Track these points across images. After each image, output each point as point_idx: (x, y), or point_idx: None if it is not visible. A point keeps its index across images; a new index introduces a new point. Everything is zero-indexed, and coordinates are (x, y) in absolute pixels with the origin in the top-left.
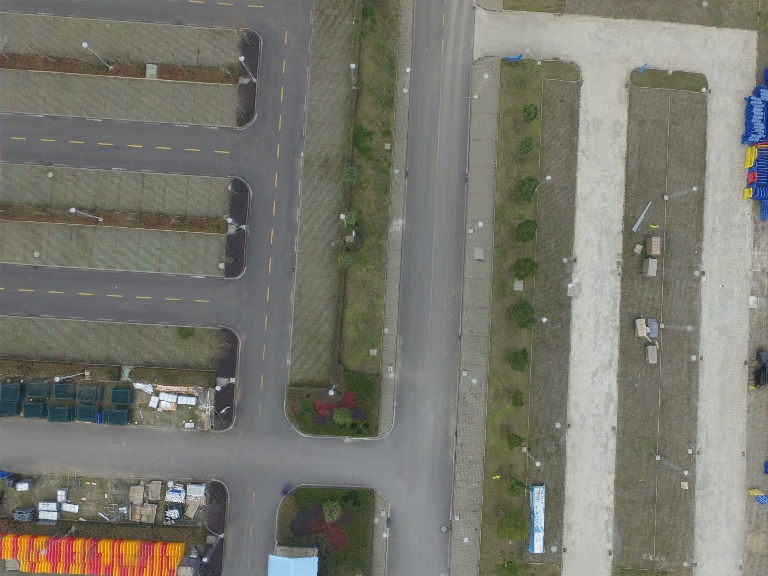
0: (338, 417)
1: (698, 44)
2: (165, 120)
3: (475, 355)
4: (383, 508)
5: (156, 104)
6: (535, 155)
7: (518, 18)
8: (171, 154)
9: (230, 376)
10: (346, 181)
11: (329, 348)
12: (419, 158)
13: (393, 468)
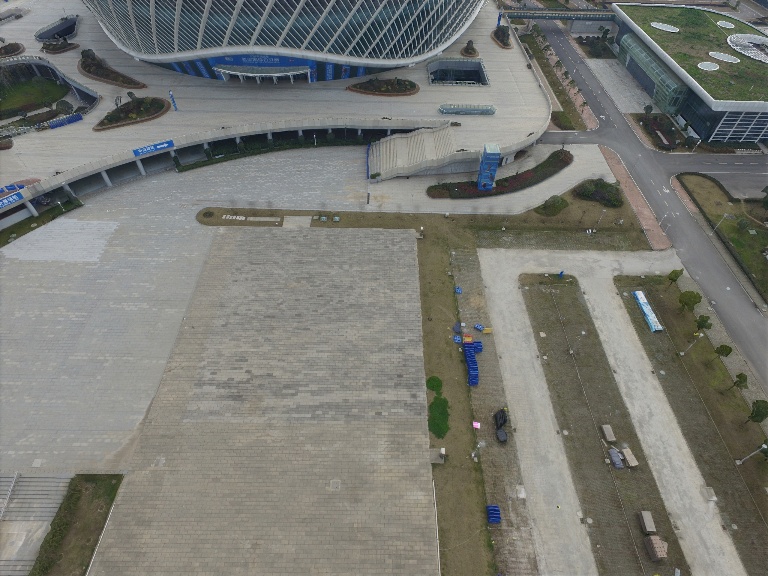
0: None
1: None
2: None
3: None
4: (766, 313)
5: None
6: None
7: None
8: None
9: None
10: None
11: None
12: None
13: None
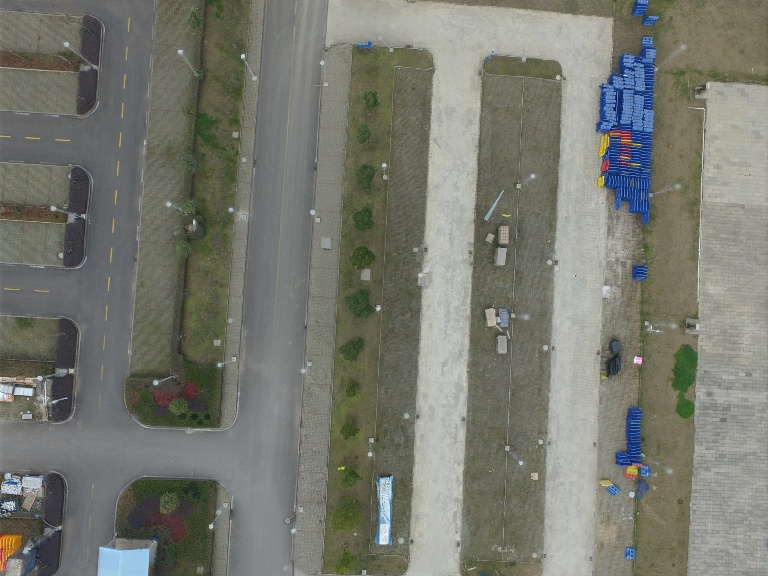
0: (172, 408)
1: (553, 31)
2: (5, 108)
3: (321, 345)
4: (225, 500)
5: None
6: (386, 143)
7: (371, 5)
8: (11, 142)
9: (68, 367)
10: (184, 169)
11: (170, 338)
12: (268, 146)
13: (236, 459)
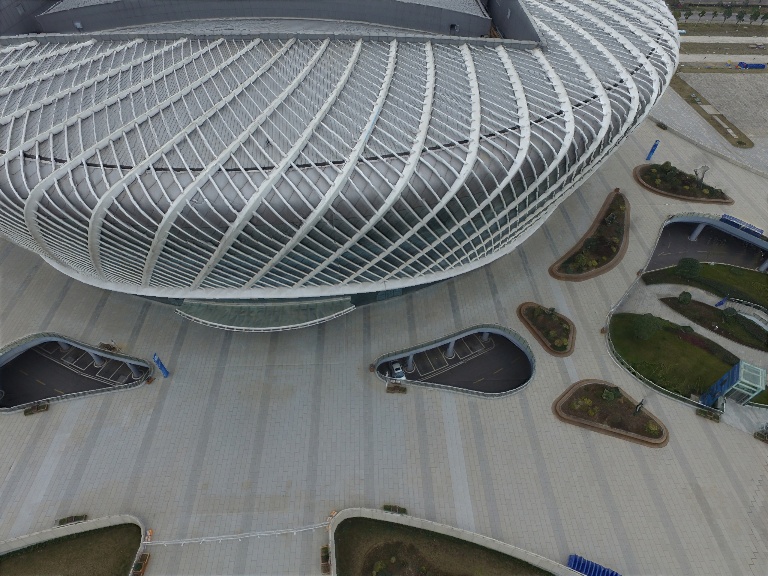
0: None
1: None
2: None
3: None
4: None
5: None
6: None
7: None
8: None
9: None
10: (743, 1)
11: None
12: None
13: None
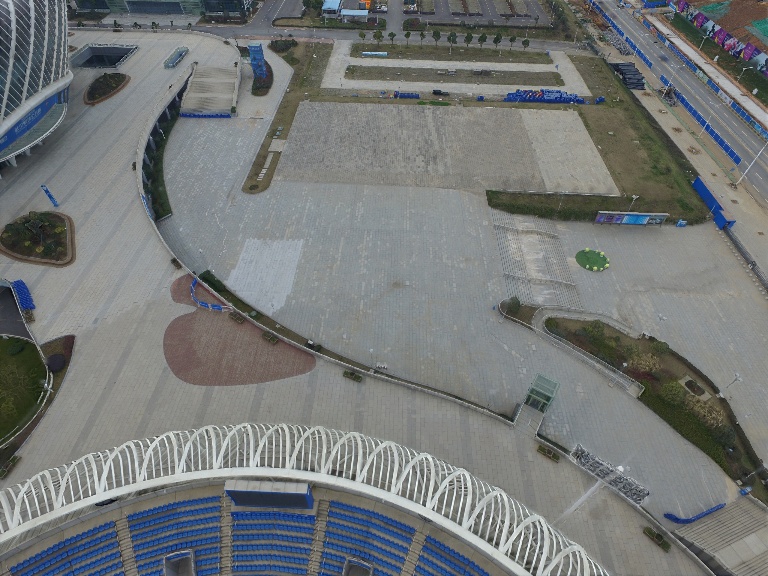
0: None
1: None
2: (497, 8)
3: None
4: None
5: (501, 7)
6: None
7: None
8: None
9: None
10: None
11: None
12: None
13: None
